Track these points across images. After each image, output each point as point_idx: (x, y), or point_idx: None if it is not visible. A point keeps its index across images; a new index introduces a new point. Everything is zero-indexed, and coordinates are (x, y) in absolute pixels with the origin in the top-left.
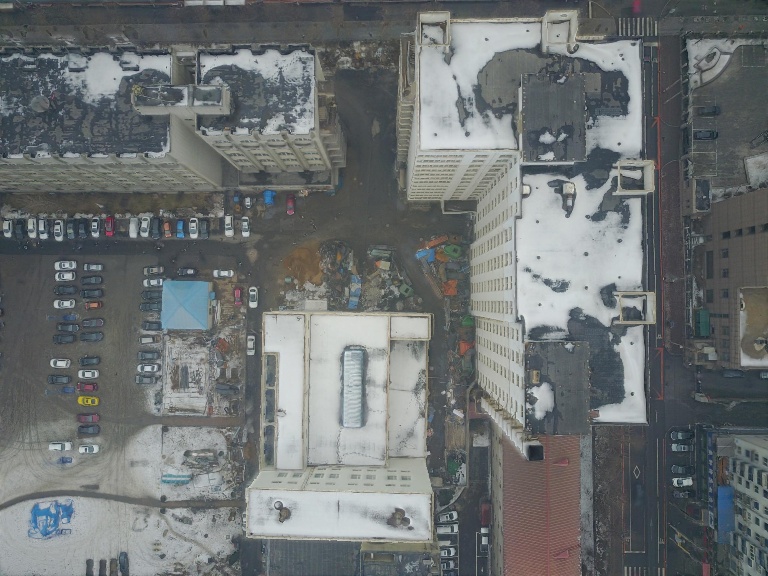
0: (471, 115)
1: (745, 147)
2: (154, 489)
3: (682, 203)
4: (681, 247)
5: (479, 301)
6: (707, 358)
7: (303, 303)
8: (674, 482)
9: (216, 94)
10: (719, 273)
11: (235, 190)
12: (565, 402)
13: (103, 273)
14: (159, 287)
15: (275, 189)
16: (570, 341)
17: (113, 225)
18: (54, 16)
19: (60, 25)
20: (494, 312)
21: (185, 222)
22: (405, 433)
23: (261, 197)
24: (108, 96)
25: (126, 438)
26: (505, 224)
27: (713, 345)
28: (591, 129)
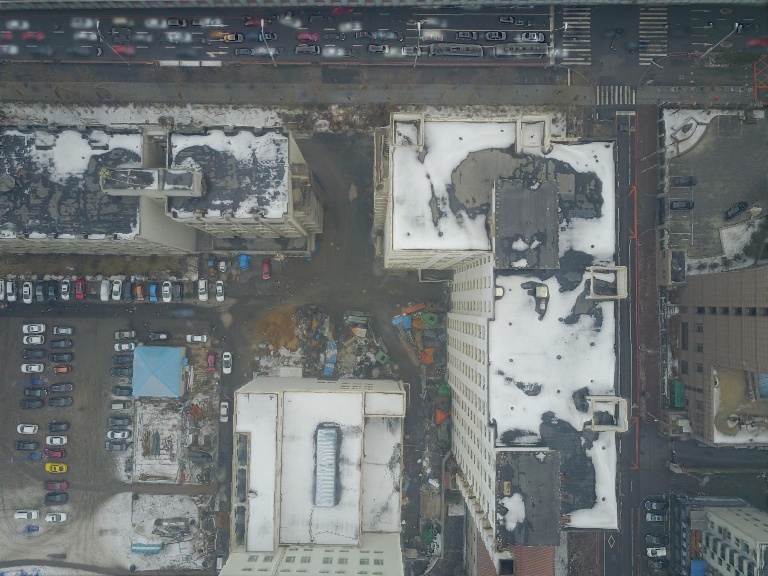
0: (445, 215)
1: (720, 217)
2: (123, 558)
3: (658, 272)
4: (657, 316)
5: (455, 375)
6: (681, 430)
7: (278, 369)
8: (648, 552)
9: (187, 178)
10: (694, 346)
11: (210, 253)
12: (536, 513)
13: (73, 336)
14: (131, 351)
15: (250, 253)
16: (541, 451)
17: (84, 288)
18: (25, 75)
19: (31, 82)
20: (468, 399)
21: (158, 285)
22: (379, 507)
23: (236, 261)
24: (76, 175)
25: (95, 506)
26: (479, 319)
27: (687, 417)
28: (565, 231)
